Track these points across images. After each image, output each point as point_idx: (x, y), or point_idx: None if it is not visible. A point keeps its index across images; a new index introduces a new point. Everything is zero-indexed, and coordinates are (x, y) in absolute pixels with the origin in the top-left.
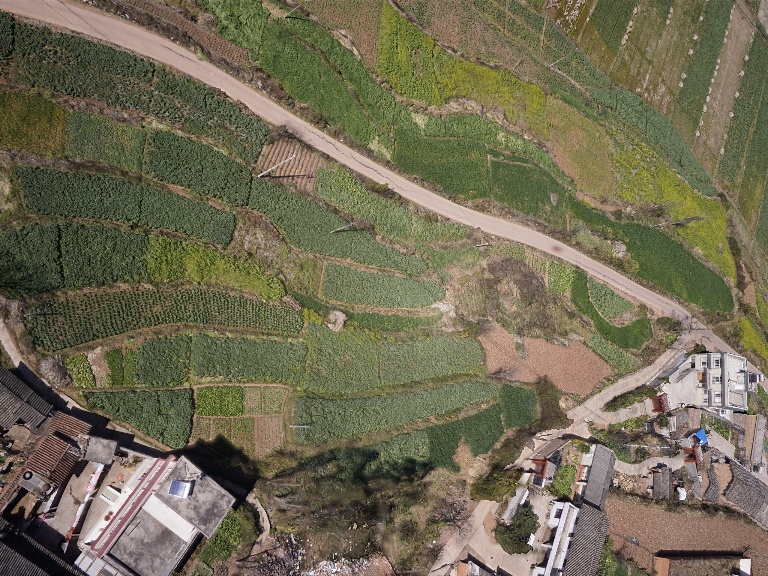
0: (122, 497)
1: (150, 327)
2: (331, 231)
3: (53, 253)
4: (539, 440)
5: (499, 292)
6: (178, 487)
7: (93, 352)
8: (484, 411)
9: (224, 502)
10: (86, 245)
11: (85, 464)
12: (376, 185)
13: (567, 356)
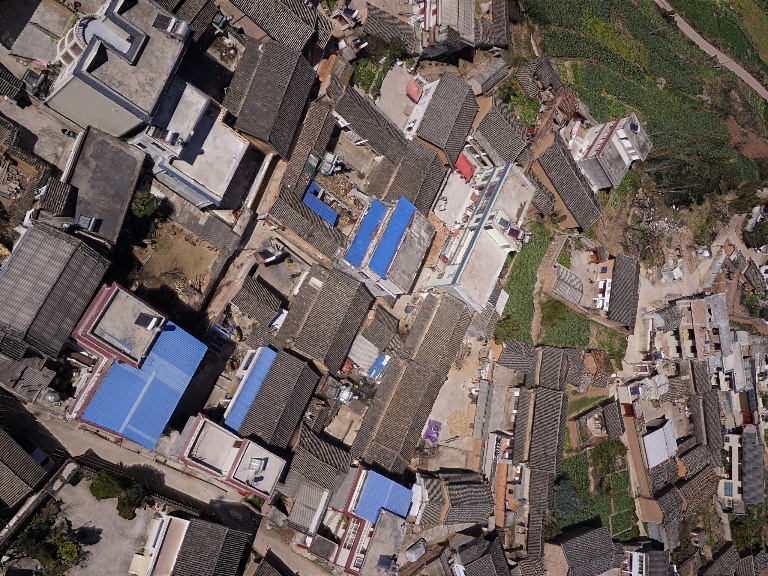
0: (585, 143)
1: (584, 58)
2: (650, 32)
3: (548, 3)
4: (759, 193)
5: (730, 98)
6: (634, 126)
7: (567, 62)
8: (733, 163)
9: (648, 145)
10: (559, 3)
11: (569, 121)
12: (667, 11)
13: (767, 151)
